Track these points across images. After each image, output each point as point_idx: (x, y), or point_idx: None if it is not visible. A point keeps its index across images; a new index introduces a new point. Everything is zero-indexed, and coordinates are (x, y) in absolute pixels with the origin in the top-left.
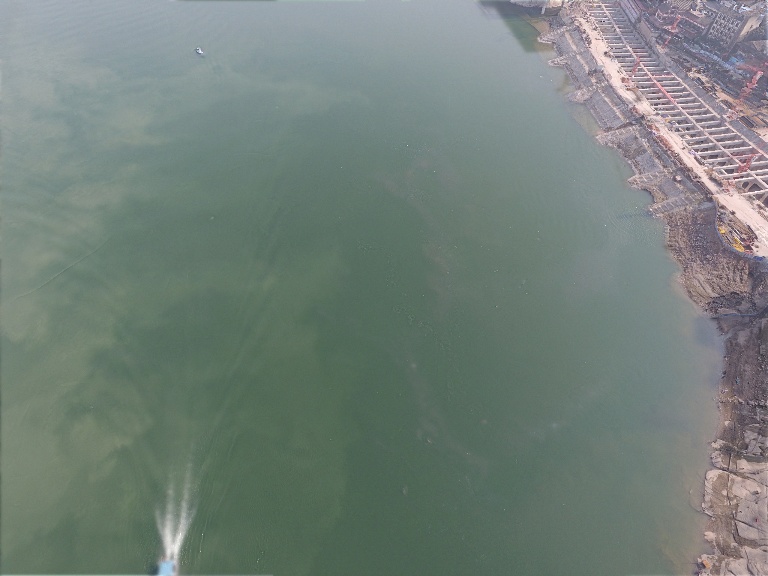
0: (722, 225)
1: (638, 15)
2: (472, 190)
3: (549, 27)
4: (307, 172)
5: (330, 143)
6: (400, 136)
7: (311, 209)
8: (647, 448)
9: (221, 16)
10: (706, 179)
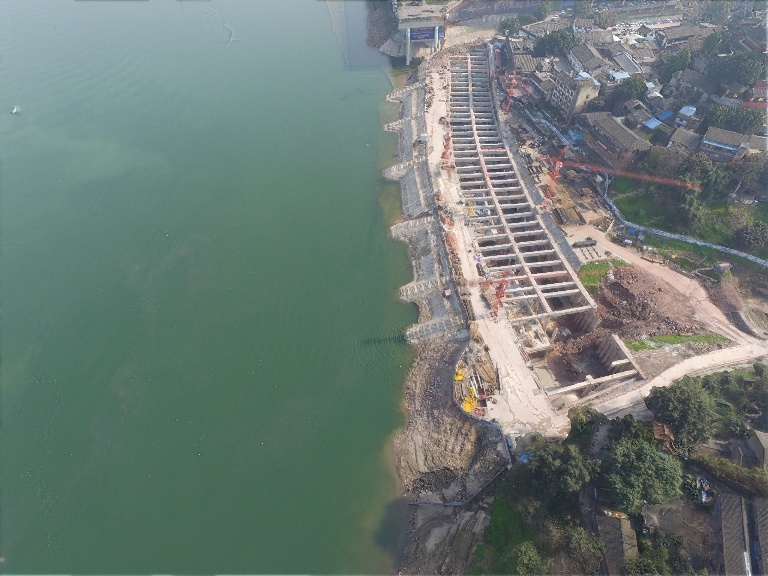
0: (465, 367)
1: (493, 72)
2: (211, 298)
3: (406, 82)
4: (31, 271)
5: (82, 231)
6: (167, 222)
7: (7, 323)
8: None
9: (55, 69)
10: (477, 296)
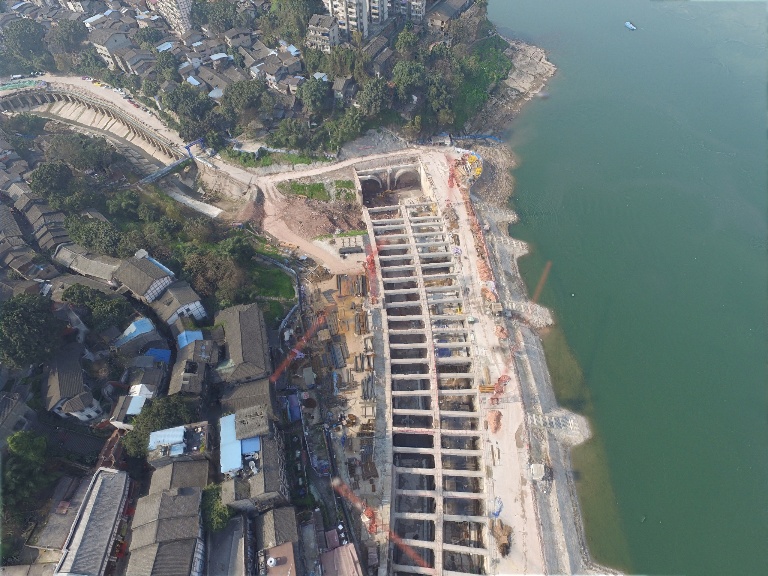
0: None
1: None
2: (707, 250)
3: None
4: None
5: None
6: None
7: None
8: (565, 100)
9: None
10: (462, 218)
